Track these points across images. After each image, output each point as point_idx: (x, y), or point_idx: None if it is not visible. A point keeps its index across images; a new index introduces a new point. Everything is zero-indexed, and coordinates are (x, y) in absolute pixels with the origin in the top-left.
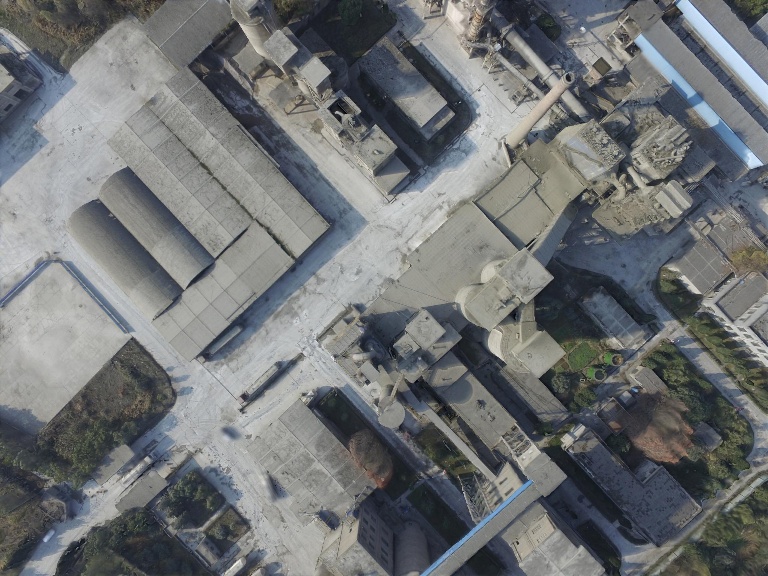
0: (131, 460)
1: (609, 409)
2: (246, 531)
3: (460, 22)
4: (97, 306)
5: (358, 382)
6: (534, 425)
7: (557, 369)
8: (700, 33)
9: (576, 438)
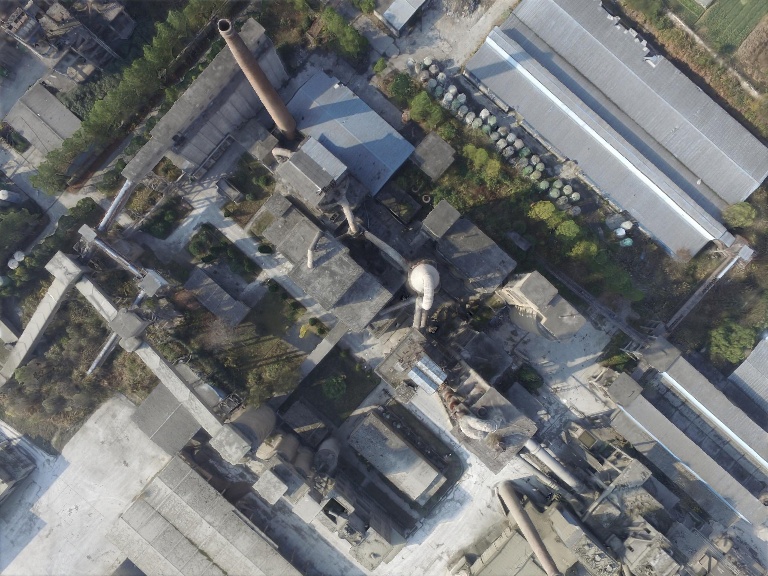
0: None
1: None
2: None
3: None
4: None
5: None
6: None
7: None
8: (680, 390)
9: None
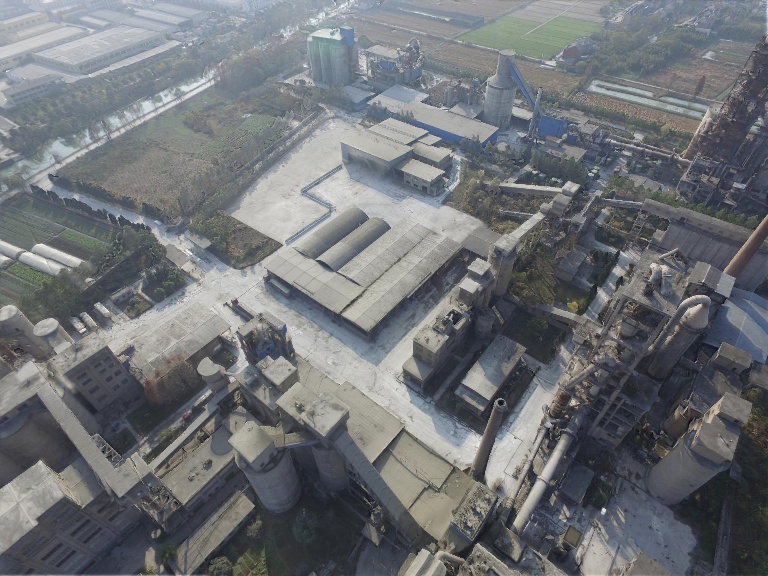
0: (200, 253)
1: None
2: (130, 317)
3: None
4: None
5: None
6: None
7: (237, 567)
8: None
9: None
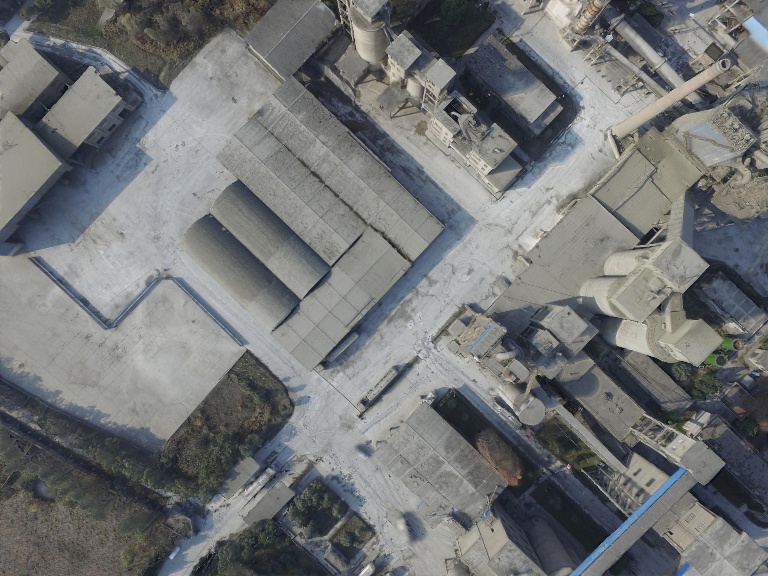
0: None
1: (733, 394)
2: (371, 537)
3: (566, 16)
4: (210, 321)
5: (503, 381)
6: (655, 414)
7: None
8: None
9: (703, 425)
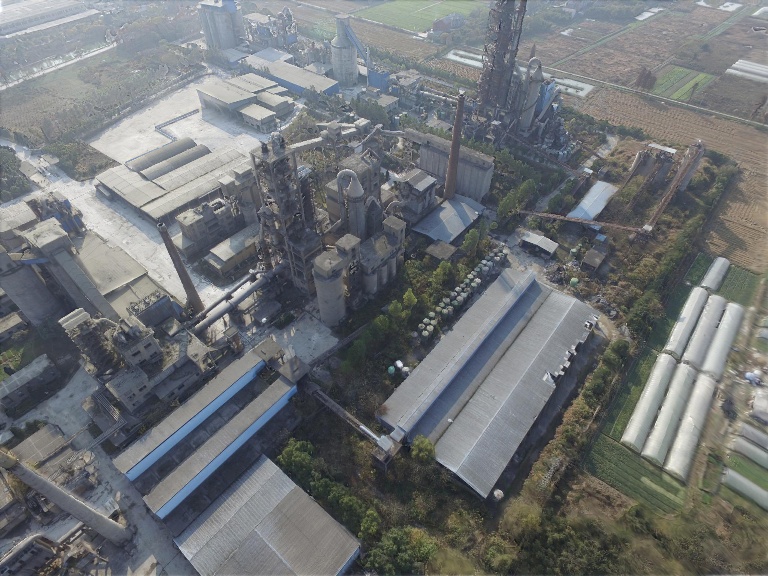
0: (52, 170)
1: None
2: None
3: None
4: None
5: None
6: None
7: None
8: None
9: None
